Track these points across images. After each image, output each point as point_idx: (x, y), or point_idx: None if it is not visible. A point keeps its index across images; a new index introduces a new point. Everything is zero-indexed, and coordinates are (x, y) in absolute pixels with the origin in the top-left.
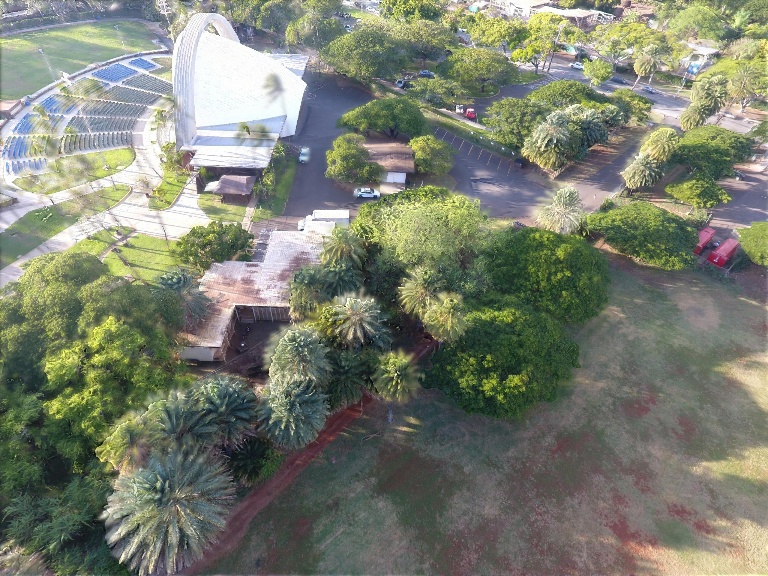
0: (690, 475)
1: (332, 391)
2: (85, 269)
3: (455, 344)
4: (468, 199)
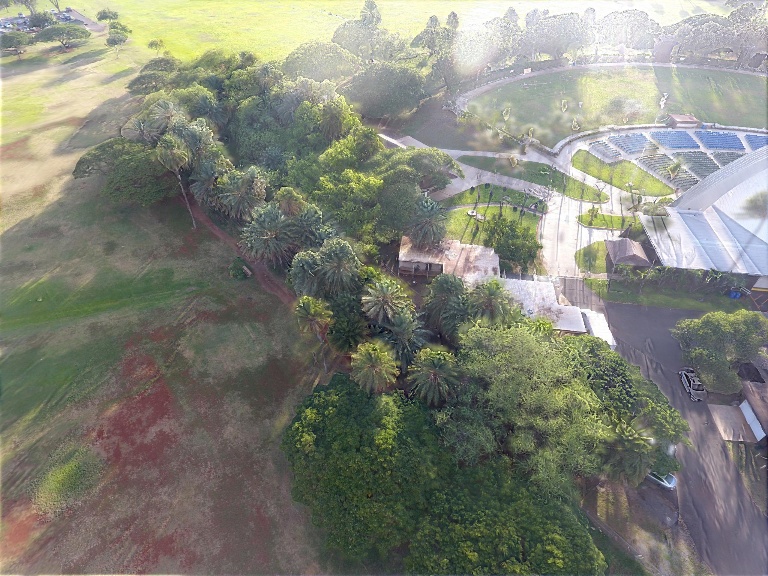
0: None
1: (328, 301)
2: (419, 162)
3: (360, 389)
4: (767, 551)
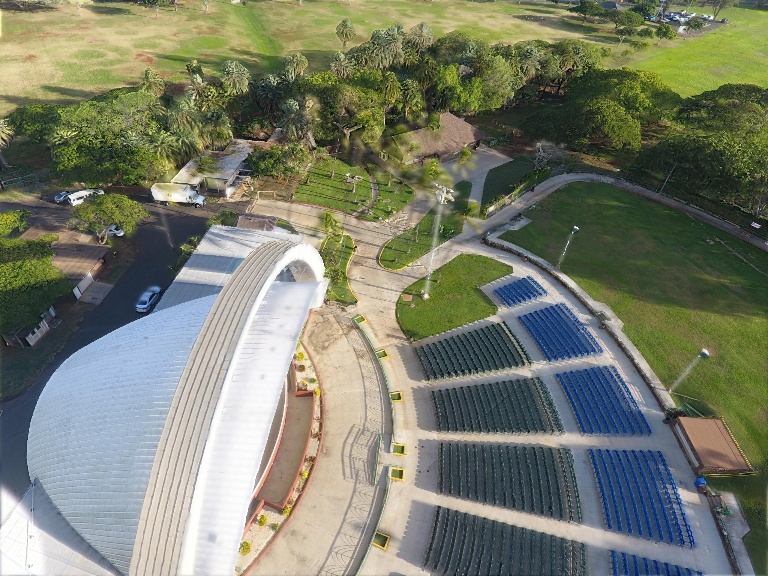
0: (88, 98)
1: None
2: None
3: None
4: None
